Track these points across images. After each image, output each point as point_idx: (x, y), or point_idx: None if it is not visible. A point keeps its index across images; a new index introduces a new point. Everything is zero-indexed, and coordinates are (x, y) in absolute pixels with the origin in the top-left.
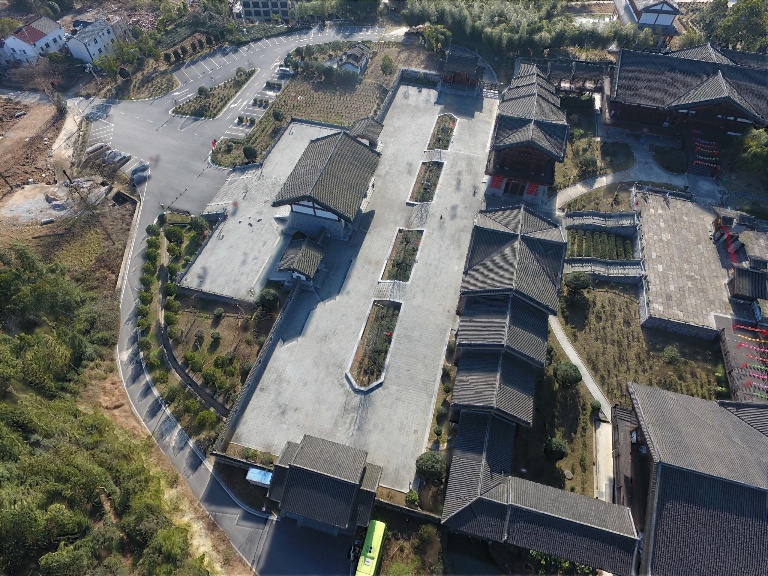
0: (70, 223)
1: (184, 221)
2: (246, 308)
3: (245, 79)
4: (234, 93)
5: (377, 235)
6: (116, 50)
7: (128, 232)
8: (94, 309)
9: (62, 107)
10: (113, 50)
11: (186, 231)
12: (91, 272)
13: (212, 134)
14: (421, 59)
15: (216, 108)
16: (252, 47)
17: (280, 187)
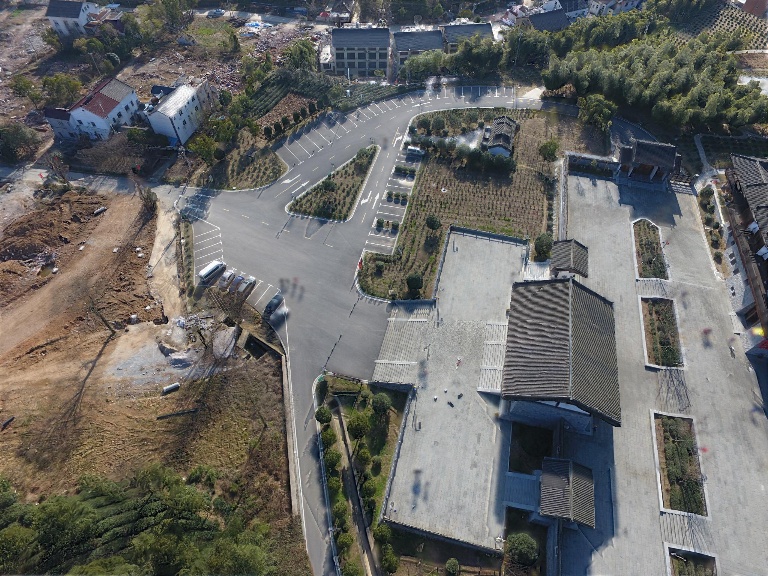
0: (201, 391)
1: (351, 389)
2: (486, 556)
3: (368, 162)
4: (360, 183)
5: (627, 424)
6: (199, 118)
7: (279, 405)
8: (281, 567)
9: (152, 203)
10: (196, 119)
11: (359, 407)
12: (247, 479)
13: (350, 245)
14: (577, 135)
15: (344, 206)
16: (362, 114)
17: (469, 338)
